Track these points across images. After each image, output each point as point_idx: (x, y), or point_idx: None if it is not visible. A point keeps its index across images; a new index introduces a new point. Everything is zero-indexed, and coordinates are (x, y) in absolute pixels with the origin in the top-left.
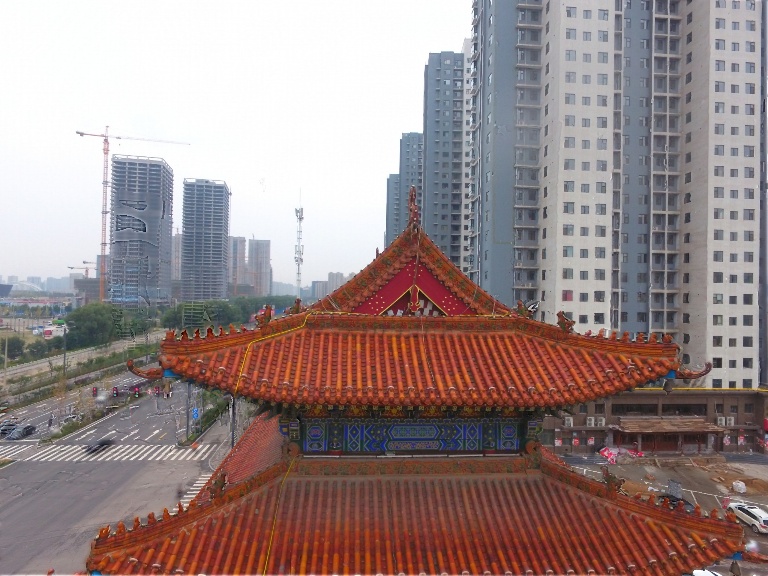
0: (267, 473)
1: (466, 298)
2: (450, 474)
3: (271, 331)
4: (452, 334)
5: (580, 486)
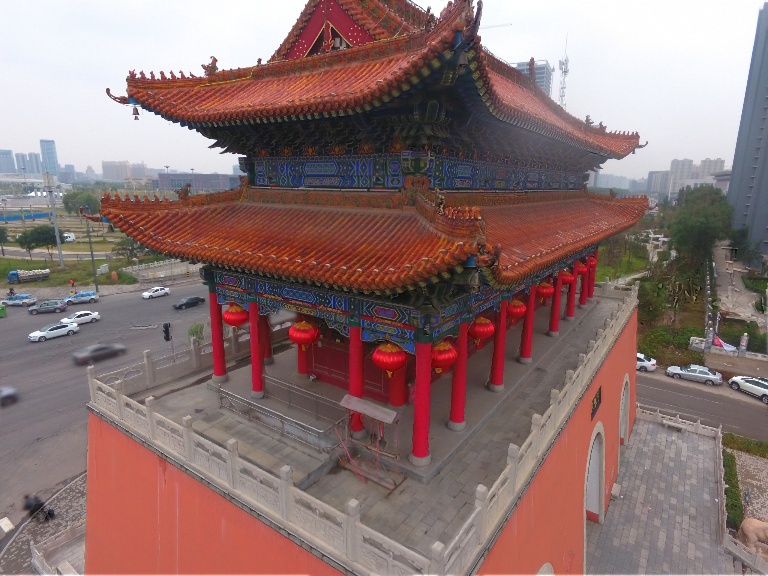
0: (225, 195)
1: (368, 24)
2: (341, 207)
3: (218, 79)
4: (351, 67)
5: (425, 215)
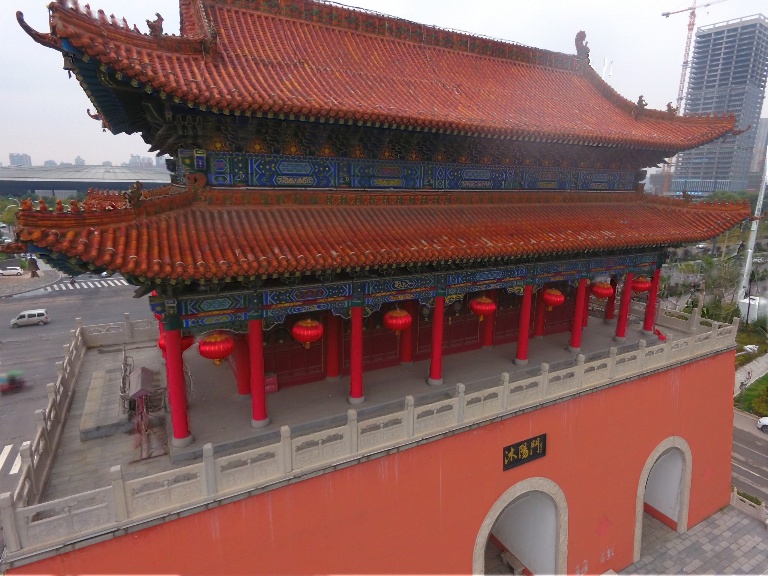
0: (161, 190)
1: None
2: None
3: None
4: None
5: None
